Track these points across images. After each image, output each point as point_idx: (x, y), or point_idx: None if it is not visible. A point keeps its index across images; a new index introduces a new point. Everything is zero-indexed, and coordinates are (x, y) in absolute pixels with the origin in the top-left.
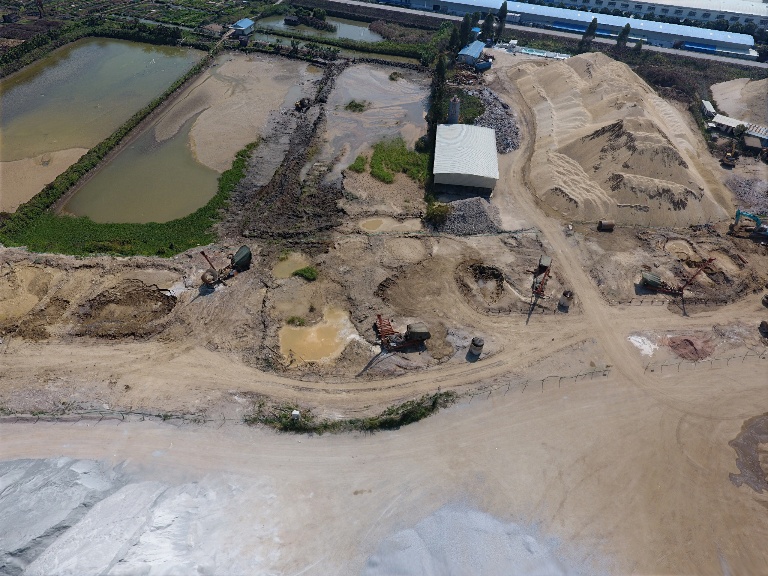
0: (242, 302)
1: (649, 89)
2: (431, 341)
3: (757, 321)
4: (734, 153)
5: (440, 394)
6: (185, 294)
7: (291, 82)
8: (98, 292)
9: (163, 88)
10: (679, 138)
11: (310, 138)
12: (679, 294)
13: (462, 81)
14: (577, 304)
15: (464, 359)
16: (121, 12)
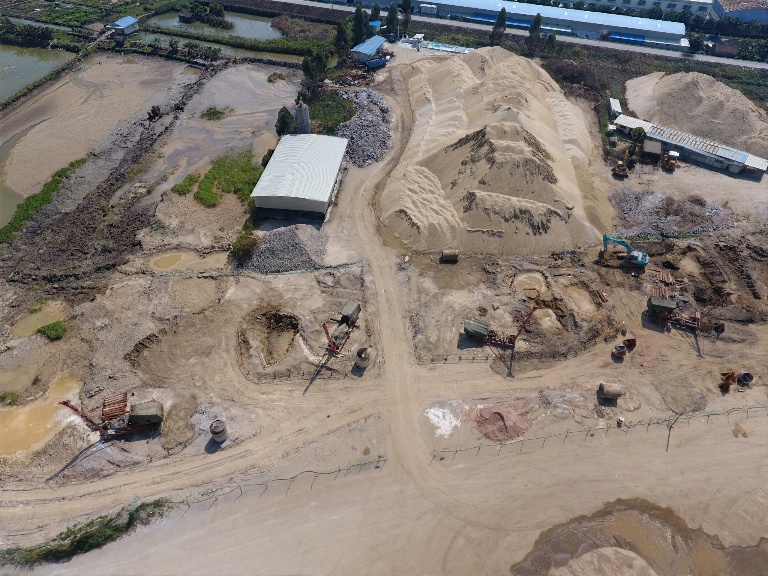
0: None
1: (551, 87)
2: (170, 423)
3: (598, 382)
4: (629, 160)
5: (147, 504)
6: None
7: (158, 87)
8: None
9: (7, 97)
10: (568, 144)
11: (142, 153)
12: (510, 346)
13: (345, 82)
14: (378, 364)
15: (202, 449)
16: None
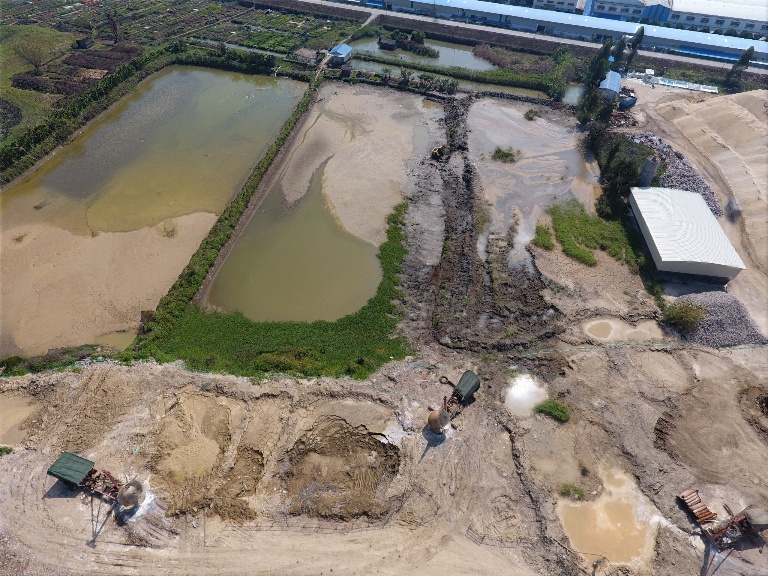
0: (486, 457)
1: None
2: None
3: None
4: None
5: None
6: (409, 443)
7: (413, 121)
8: (295, 438)
9: (273, 130)
10: None
11: (471, 200)
12: None
13: (614, 122)
14: None
15: None
16: (200, 35)
